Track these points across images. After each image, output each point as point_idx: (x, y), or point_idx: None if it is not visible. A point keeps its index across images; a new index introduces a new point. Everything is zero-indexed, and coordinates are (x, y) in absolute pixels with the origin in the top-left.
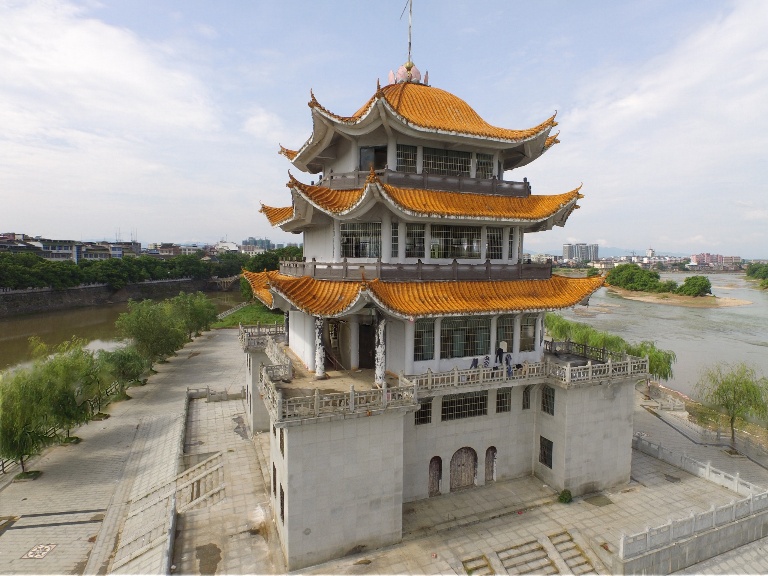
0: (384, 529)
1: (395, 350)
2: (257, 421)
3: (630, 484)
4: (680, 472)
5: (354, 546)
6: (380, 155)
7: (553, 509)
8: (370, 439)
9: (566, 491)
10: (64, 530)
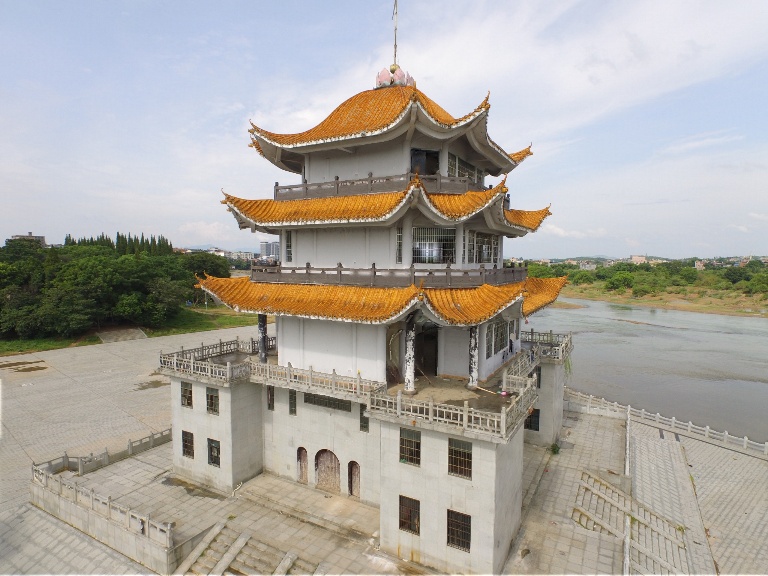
0: (517, 518)
1: (457, 353)
2: (236, 471)
3: (564, 429)
4: (571, 413)
5: (510, 543)
6: (432, 160)
7: (557, 460)
8: (516, 437)
9: (554, 445)
10: None
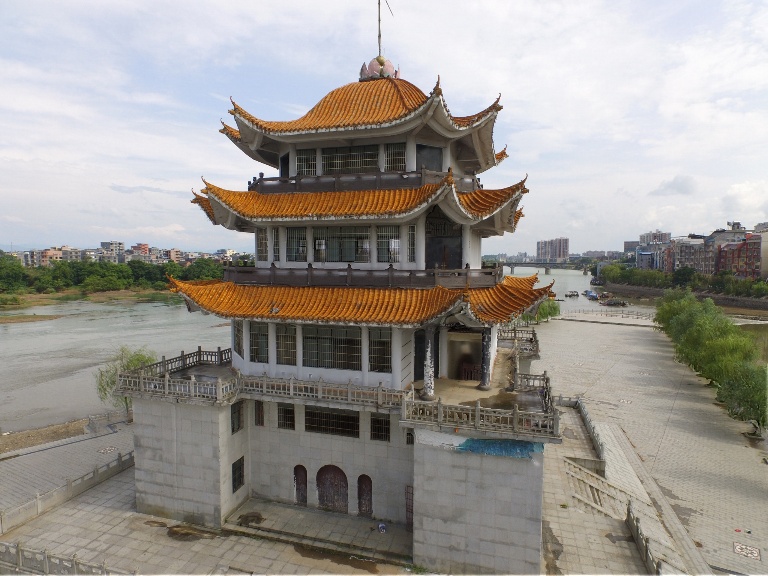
0: None
1: None
2: None
3: None
4: None
5: None
6: None
7: None
8: None
9: None
10: (748, 569)
